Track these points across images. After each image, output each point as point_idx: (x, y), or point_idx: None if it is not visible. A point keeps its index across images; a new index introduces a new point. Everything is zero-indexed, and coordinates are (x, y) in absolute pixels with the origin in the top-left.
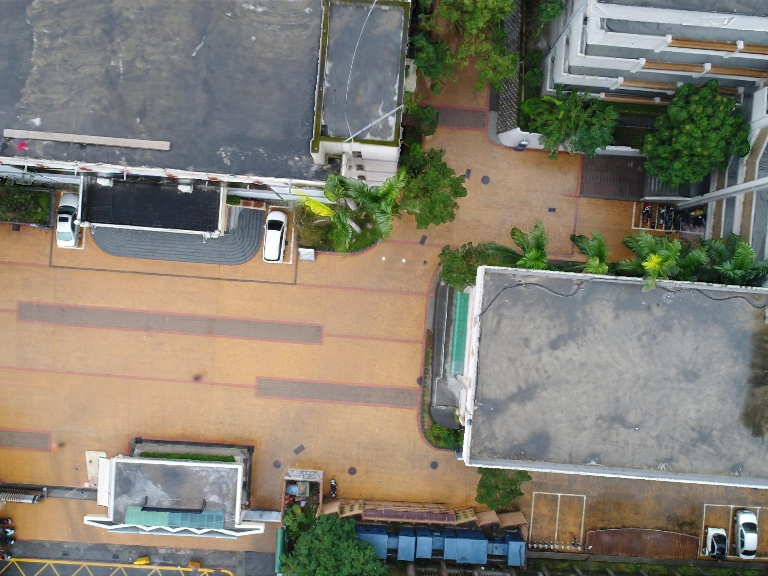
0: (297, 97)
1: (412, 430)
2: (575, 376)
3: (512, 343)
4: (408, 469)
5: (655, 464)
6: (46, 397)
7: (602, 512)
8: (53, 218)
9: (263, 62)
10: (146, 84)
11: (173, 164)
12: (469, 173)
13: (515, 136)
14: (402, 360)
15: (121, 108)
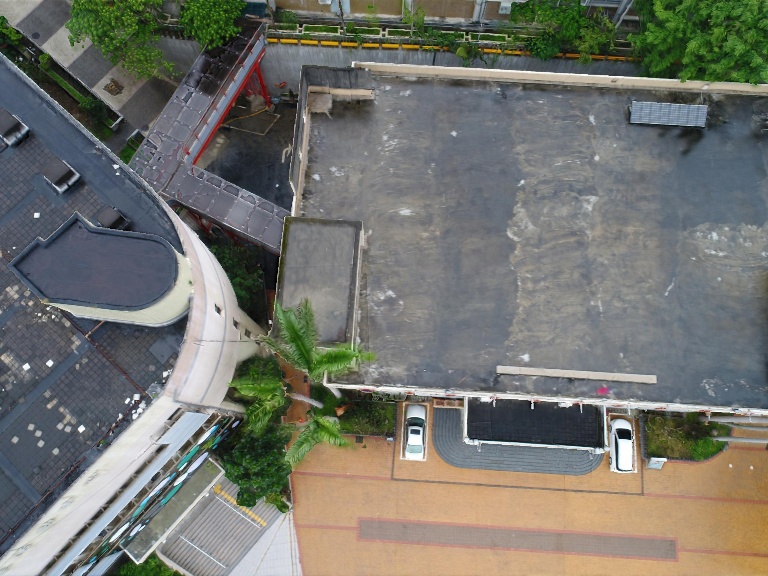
0: None
1: None
2: None
3: None
4: None
5: None
6: None
7: None
8: (397, 429)
9: (731, 300)
10: (625, 321)
11: (660, 396)
12: None
13: None
14: None
15: (604, 344)
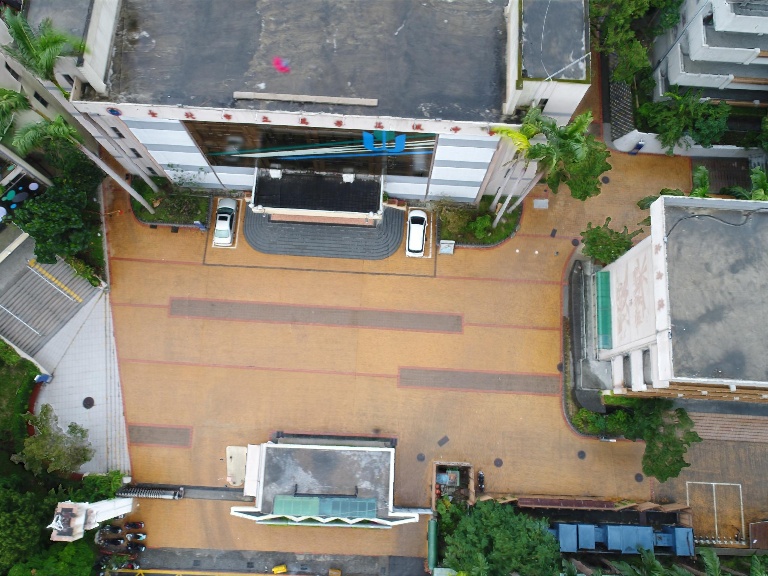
0: (485, 64)
1: (556, 418)
2: (758, 297)
3: (694, 268)
4: (555, 459)
5: None
6: (190, 391)
7: (761, 502)
8: (210, 220)
9: (455, 38)
10: (356, 56)
11: None
12: None
13: (632, 138)
14: (541, 347)
15: (334, 75)
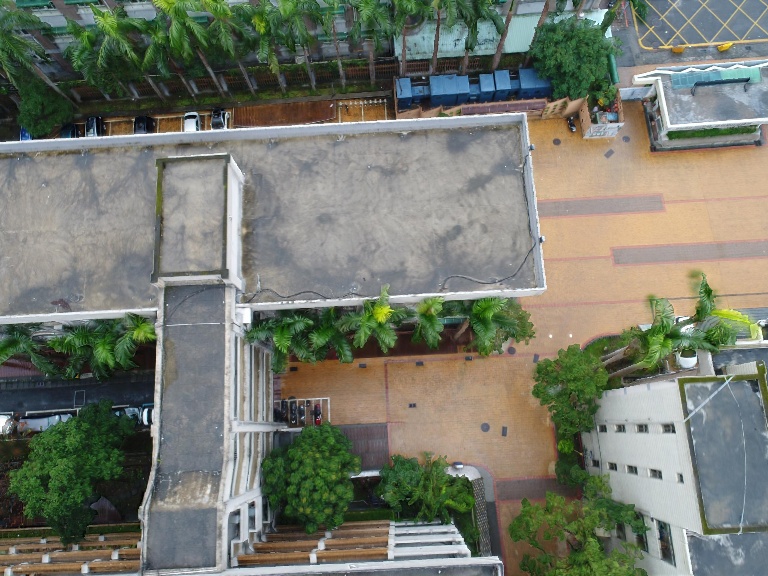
0: None
1: None
2: (434, 205)
3: (498, 227)
4: None
5: (348, 139)
6: None
7: None
8: None
9: None
10: None
11: None
12: (503, 432)
13: (470, 473)
14: None
15: None
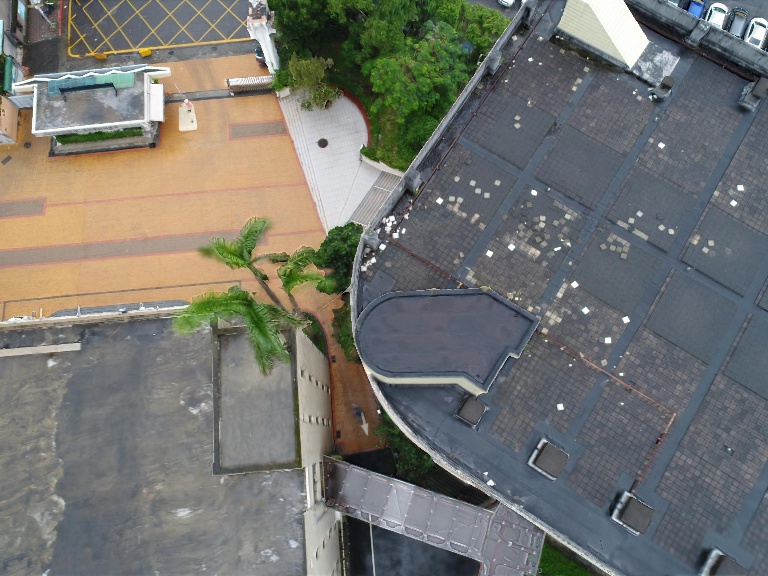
0: None
1: None
2: None
3: None
4: None
5: None
6: (236, 168)
7: None
8: None
9: None
10: None
11: None
12: None
13: None
14: None
15: None
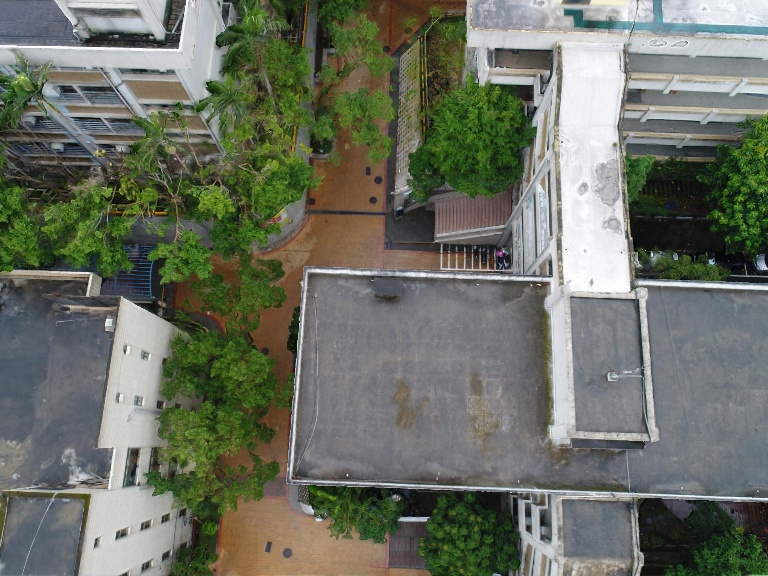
0: None
1: None
2: None
3: None
4: None
5: None
6: None
7: None
8: None
9: None
10: None
11: None
12: (270, 546)
13: (310, 511)
14: None
15: None
